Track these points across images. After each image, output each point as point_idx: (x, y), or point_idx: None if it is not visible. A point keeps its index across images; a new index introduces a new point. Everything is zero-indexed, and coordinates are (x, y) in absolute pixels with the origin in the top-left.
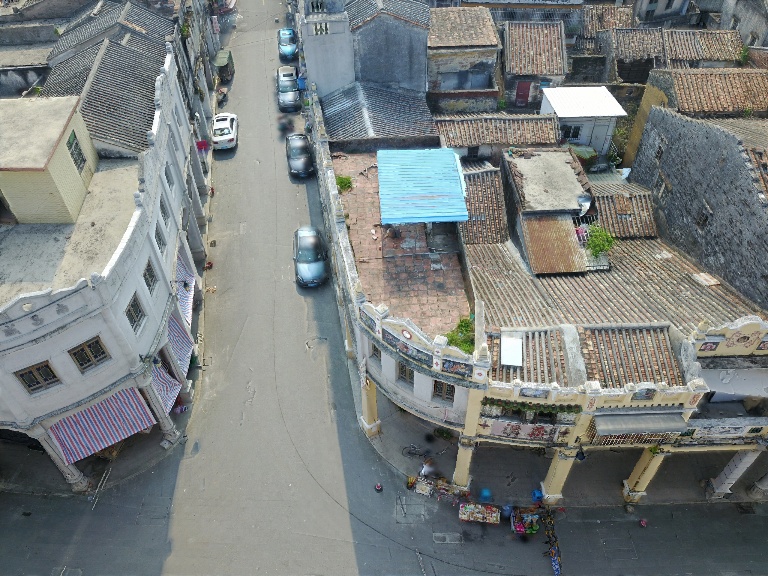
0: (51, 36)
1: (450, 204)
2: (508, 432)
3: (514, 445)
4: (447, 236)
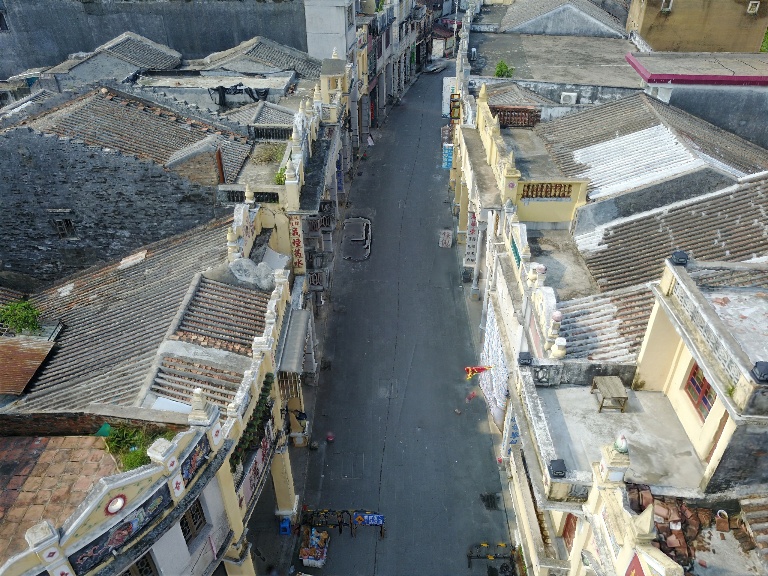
0: None
1: None
2: (253, 482)
3: None
4: None
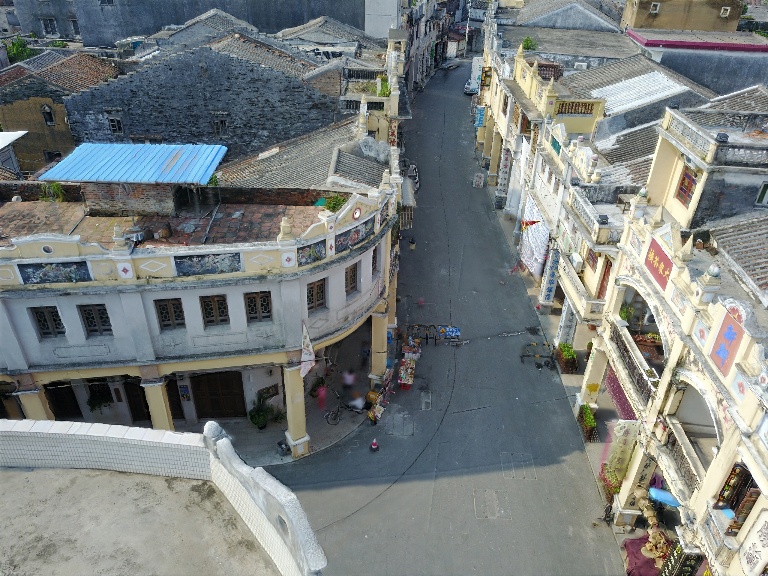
0: None
1: (197, 150)
2: None
3: (338, 343)
4: (185, 210)
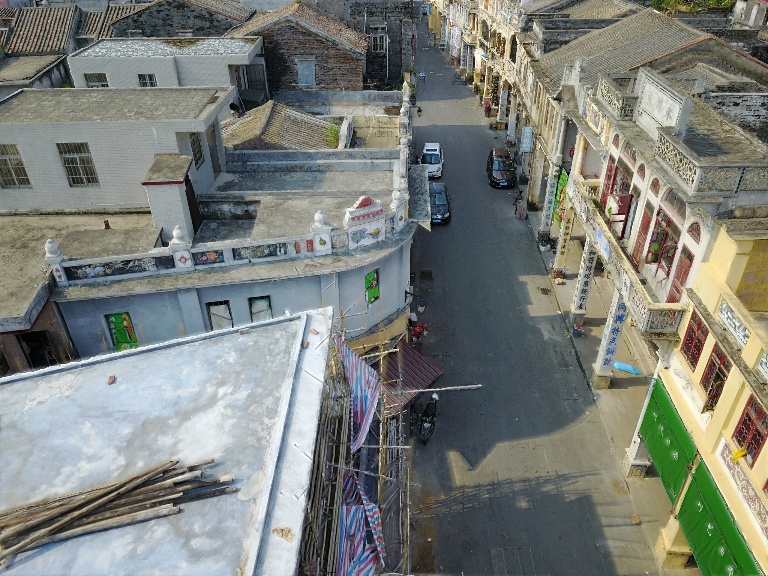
0: (0, 53)
1: None
2: None
3: None
4: None
